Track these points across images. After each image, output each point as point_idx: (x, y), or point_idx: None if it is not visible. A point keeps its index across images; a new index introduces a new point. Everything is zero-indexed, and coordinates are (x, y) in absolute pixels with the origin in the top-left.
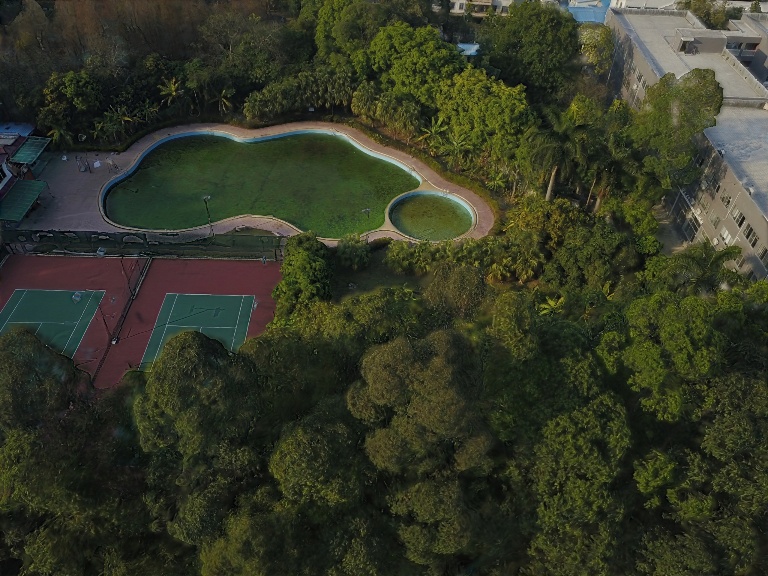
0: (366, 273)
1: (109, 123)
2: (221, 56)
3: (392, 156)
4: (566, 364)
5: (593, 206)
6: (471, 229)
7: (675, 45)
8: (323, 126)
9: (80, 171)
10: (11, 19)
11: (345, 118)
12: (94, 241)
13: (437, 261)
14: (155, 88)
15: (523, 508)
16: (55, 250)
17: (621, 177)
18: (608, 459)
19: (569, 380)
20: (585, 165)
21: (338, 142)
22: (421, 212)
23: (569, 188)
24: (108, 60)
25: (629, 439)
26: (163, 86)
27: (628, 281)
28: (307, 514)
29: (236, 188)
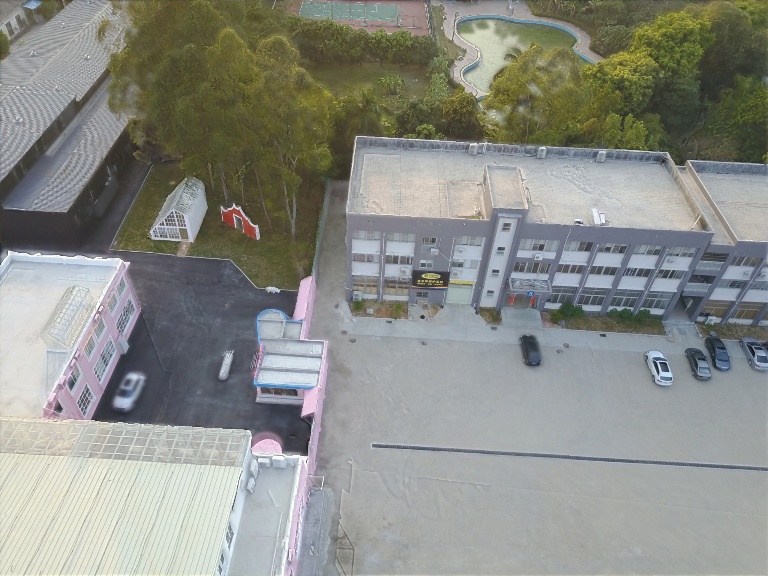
0: (429, 84)
1: None
2: (640, 1)
3: None
4: None
5: None
6: None
7: None
8: None
9: (506, 7)
10: None
11: None
12: (441, 16)
13: None
14: None
15: None
16: None
17: None
18: None
19: None
20: None
21: None
22: None
23: None
24: None
25: None
26: None
27: (401, 137)
28: None
29: None
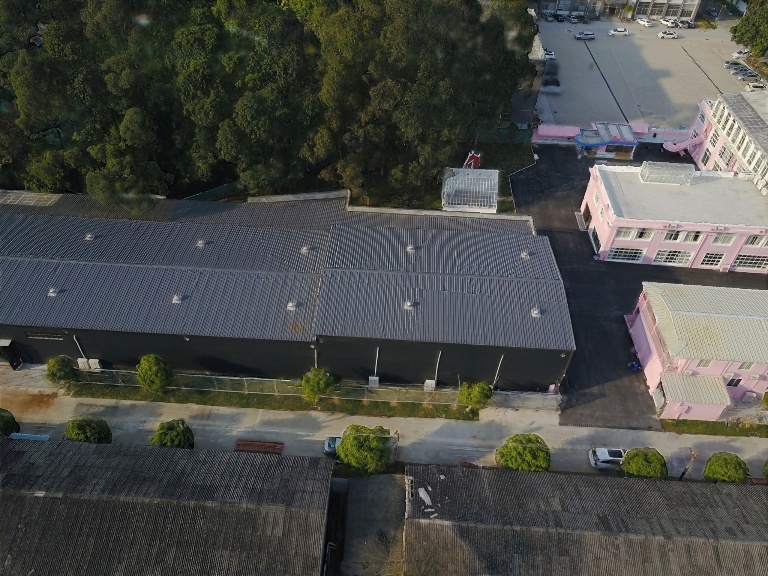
0: None
1: (44, 3)
2: None
3: None
4: (192, 10)
5: None
6: None
7: None
8: None
9: None
10: None
11: None
12: None
13: None
14: None
15: (176, 85)
16: None
17: None
18: (205, 49)
19: (191, 15)
20: None
21: None
22: None
23: None
24: None
25: (215, 39)
26: None
27: None
28: (57, 60)
29: None
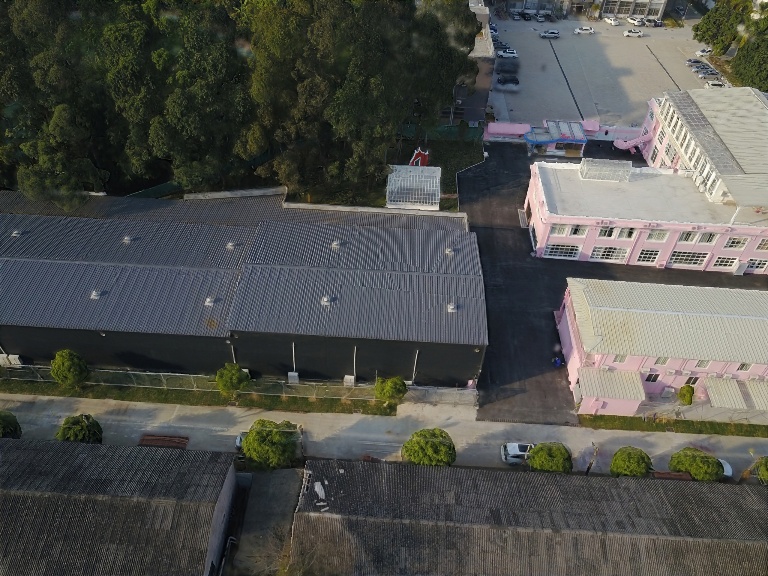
0: None
1: None
2: None
3: None
4: (121, 6)
5: None
6: None
7: None
8: None
9: None
10: None
11: None
12: None
13: None
14: None
15: None
16: None
17: None
18: (133, 45)
19: (120, 12)
20: None
21: None
22: None
23: None
24: None
25: (143, 36)
26: None
27: None
28: None
29: None
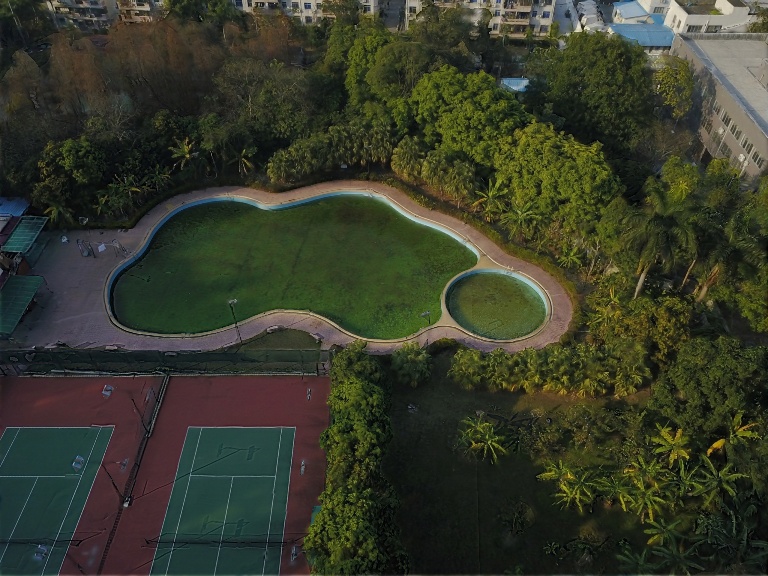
0: (427, 389)
1: (114, 196)
2: (240, 109)
3: (441, 223)
4: None
5: (690, 286)
6: (546, 321)
7: (764, 79)
8: (358, 186)
9: (83, 256)
10: (4, 68)
11: (383, 175)
12: None
13: (515, 375)
14: (166, 150)
15: None
16: (54, 370)
17: (737, 264)
18: None
19: None
20: (695, 253)
21: (377, 205)
22: (483, 297)
23: (662, 267)
24: (111, 122)
25: None
26: (175, 147)
27: (765, 409)
28: None
29: (263, 271)
